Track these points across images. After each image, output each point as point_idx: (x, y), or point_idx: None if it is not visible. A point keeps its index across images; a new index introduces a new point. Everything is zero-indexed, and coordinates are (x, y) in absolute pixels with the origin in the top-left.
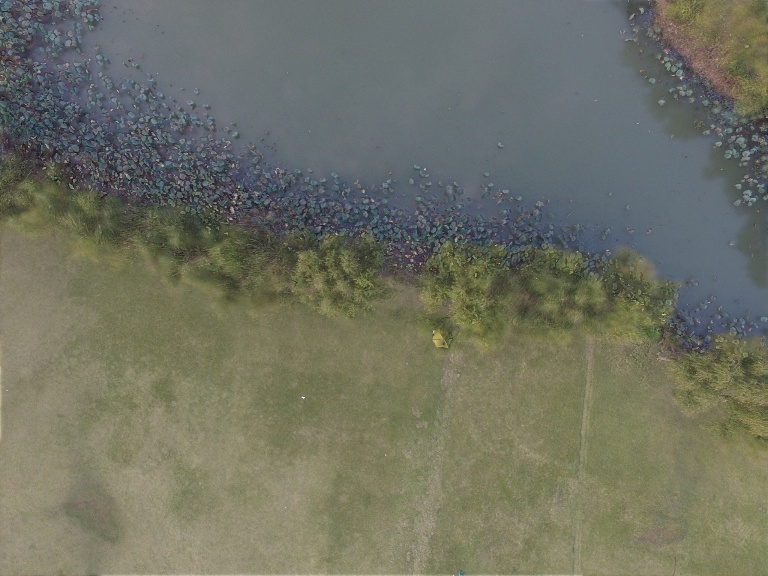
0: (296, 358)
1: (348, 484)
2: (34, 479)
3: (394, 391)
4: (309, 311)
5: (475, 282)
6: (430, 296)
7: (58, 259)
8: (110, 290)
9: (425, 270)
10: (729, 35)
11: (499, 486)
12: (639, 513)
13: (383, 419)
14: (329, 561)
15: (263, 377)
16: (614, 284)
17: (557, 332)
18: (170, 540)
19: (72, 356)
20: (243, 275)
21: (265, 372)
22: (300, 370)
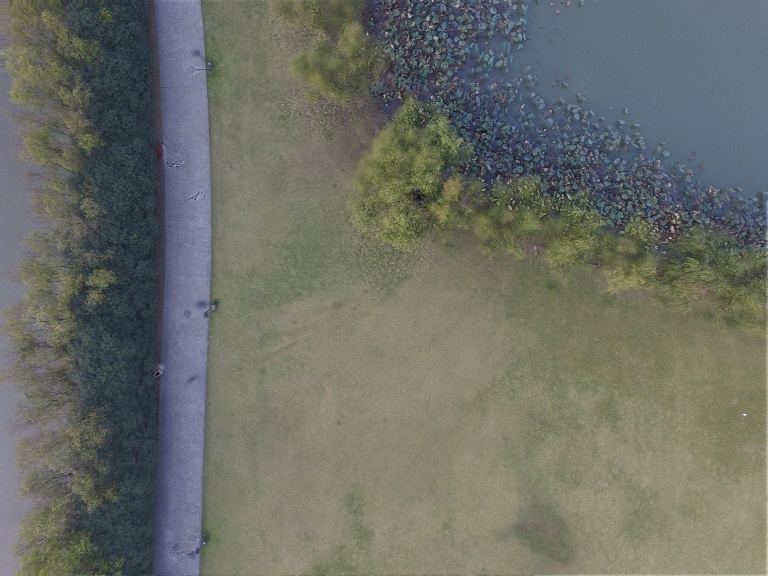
0: (734, 376)
1: None
2: (484, 502)
3: None
4: (743, 328)
5: None
6: None
7: (493, 281)
8: (547, 311)
9: None
10: None
11: None
12: None
13: None
14: None
15: (704, 395)
16: None
17: None
18: (623, 559)
19: (514, 378)
20: (678, 294)
21: (706, 390)
22: (739, 387)
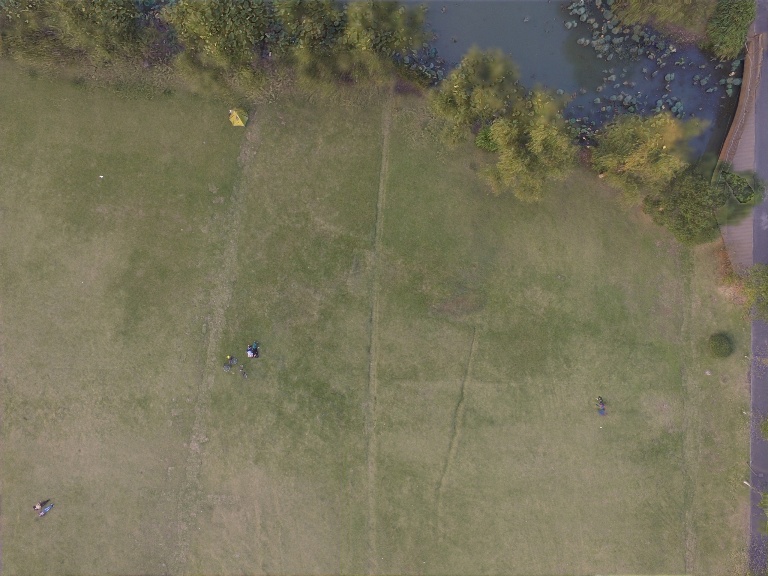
0: (95, 140)
1: (145, 259)
2: None
3: (191, 169)
4: (109, 95)
5: (270, 61)
6: (227, 77)
7: None
8: None
9: (220, 50)
10: None
11: (295, 258)
12: (437, 284)
13: (179, 195)
14: (125, 334)
15: (62, 158)
16: (406, 58)
17: (353, 109)
18: None
19: None
20: (45, 62)
21: (64, 153)
22: (99, 151)
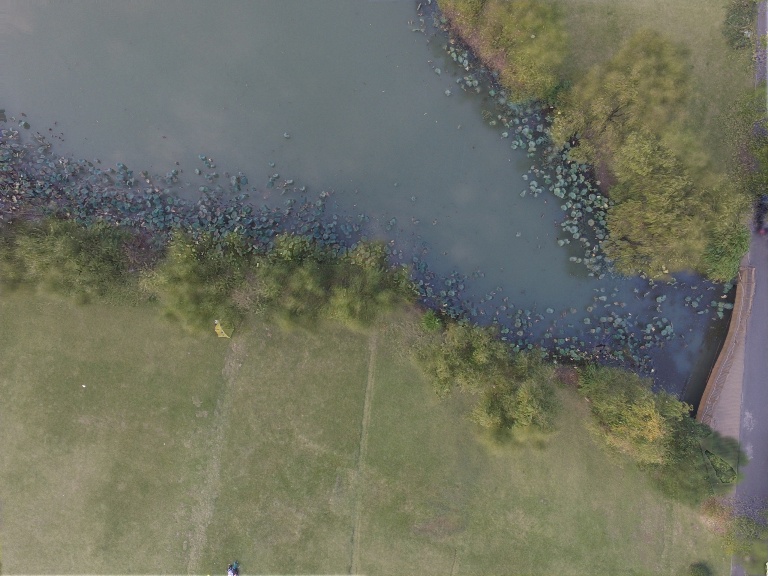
0: (79, 347)
1: (126, 473)
2: None
3: (175, 380)
4: (93, 300)
5: (257, 272)
6: (214, 286)
7: None
8: None
9: (207, 260)
10: (515, 25)
11: (277, 476)
12: (420, 504)
13: (163, 408)
14: (105, 549)
15: (45, 366)
16: (395, 274)
17: (340, 322)
18: None
19: None
20: (28, 264)
21: (47, 361)
22: (82, 359)
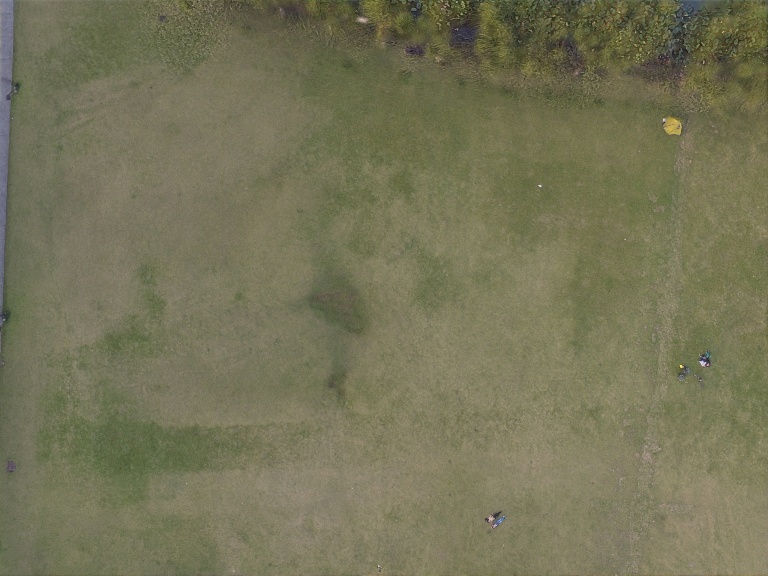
0: (530, 149)
1: (590, 269)
2: (278, 273)
3: (629, 178)
4: (539, 104)
5: (703, 69)
6: (658, 86)
7: (289, 61)
8: (342, 89)
9: (654, 58)
10: None
11: (739, 267)
12: None
13: (620, 204)
14: (575, 344)
15: (499, 167)
16: None
17: None
18: (417, 328)
19: (309, 153)
20: (473, 71)
21: (501, 163)
22: (535, 160)
